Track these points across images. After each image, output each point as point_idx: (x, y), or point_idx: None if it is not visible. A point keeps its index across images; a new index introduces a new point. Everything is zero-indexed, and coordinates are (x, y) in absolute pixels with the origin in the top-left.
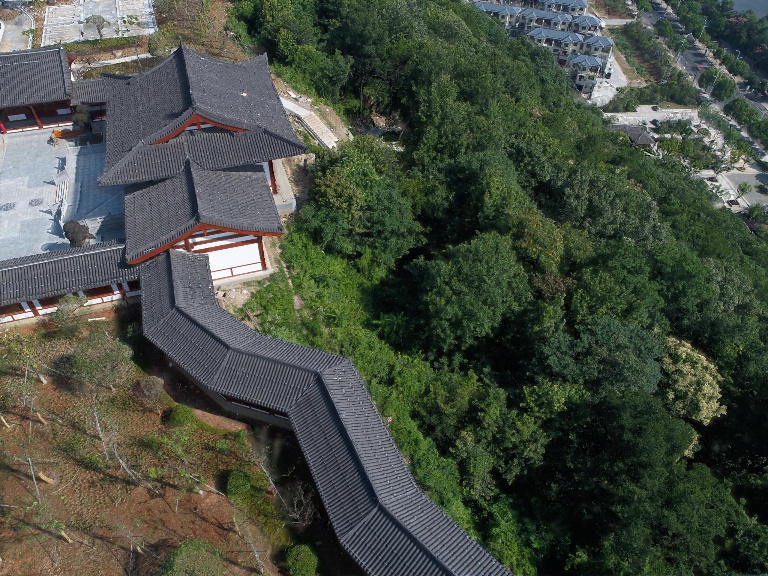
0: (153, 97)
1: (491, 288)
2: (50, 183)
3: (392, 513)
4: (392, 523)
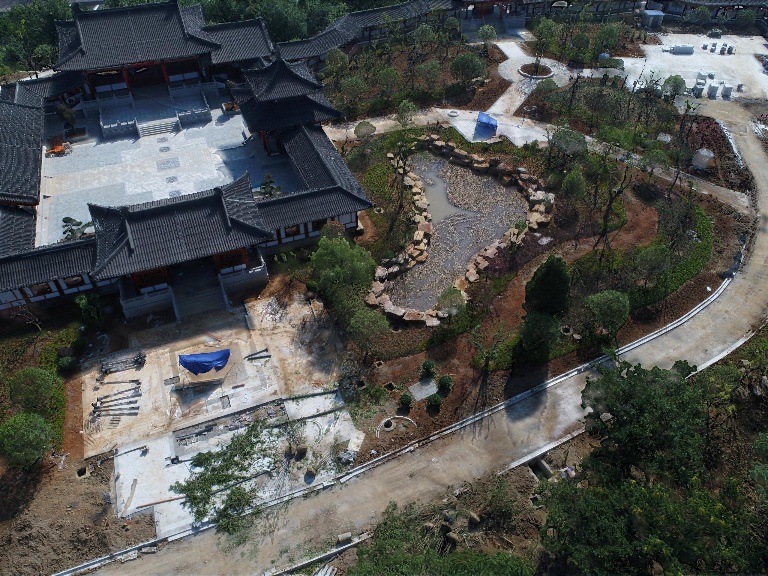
0: (125, 36)
1: (294, 0)
2: (136, 140)
3: (403, 4)
4: (405, 6)
